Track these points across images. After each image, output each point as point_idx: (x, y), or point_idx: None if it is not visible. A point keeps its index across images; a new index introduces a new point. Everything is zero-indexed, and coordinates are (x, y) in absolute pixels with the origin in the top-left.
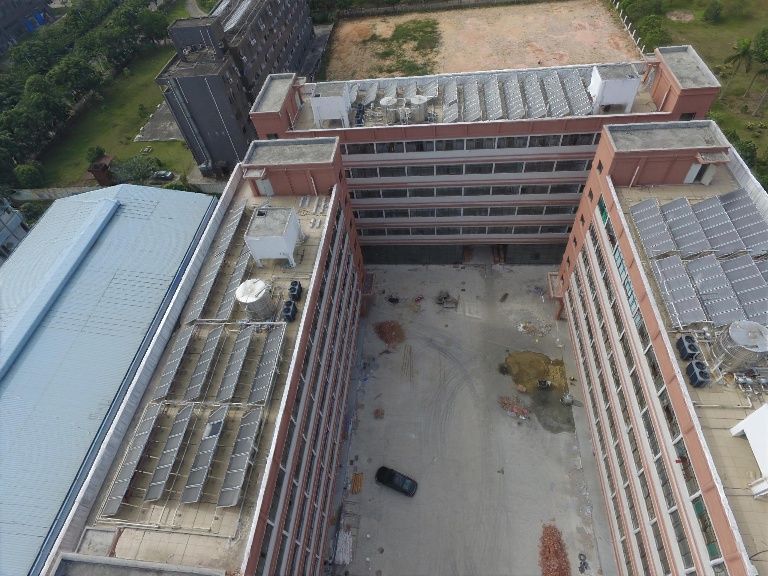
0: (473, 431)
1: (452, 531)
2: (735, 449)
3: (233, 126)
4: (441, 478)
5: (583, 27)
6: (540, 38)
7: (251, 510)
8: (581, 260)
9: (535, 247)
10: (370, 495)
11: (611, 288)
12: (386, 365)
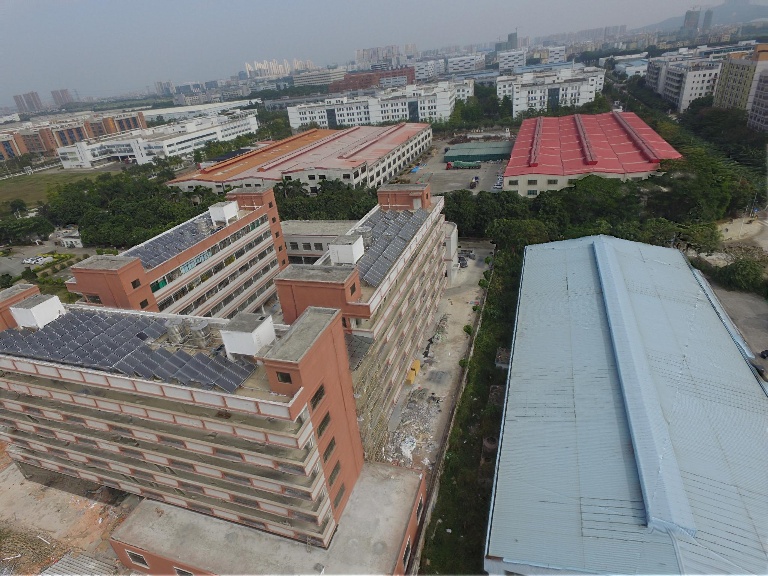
0: None
1: None
2: None
3: None
4: None
5: None
6: None
7: None
8: None
9: None
10: None
11: None
12: None
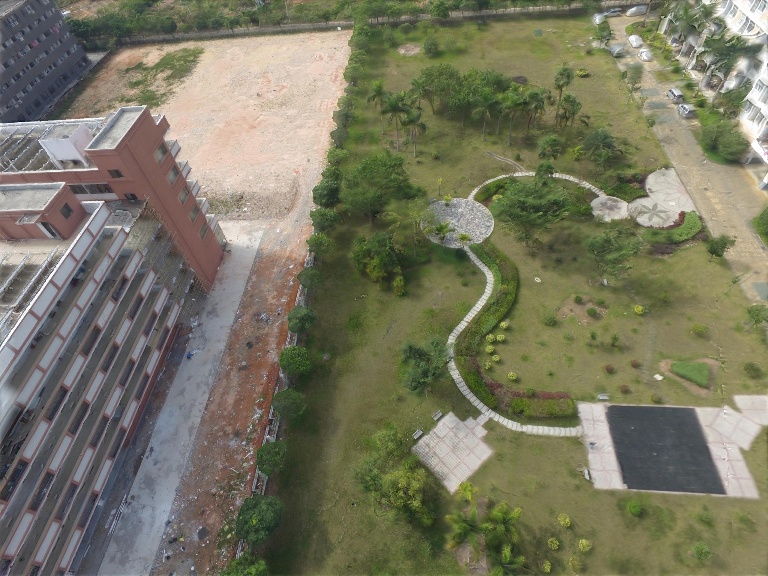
0: None
1: None
2: None
3: None
4: None
5: (321, 59)
6: (277, 69)
7: None
8: None
9: None
10: None
11: None
12: None
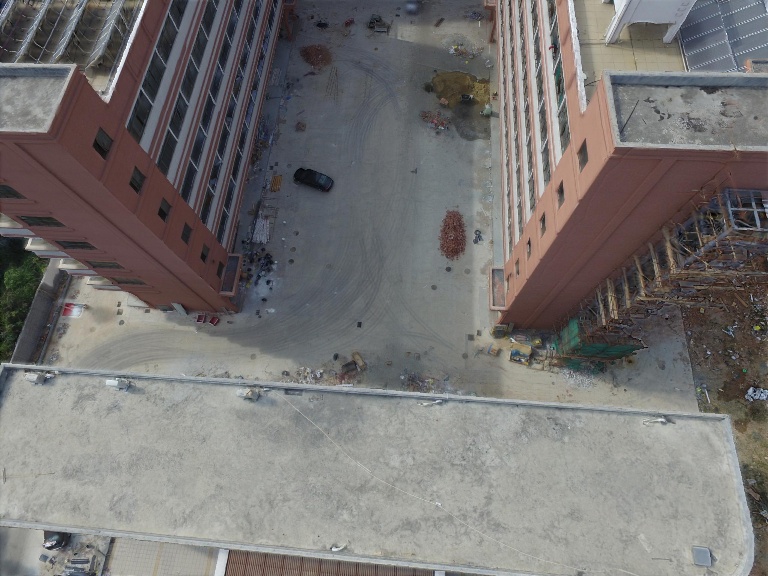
0: (392, 140)
1: (363, 217)
2: (601, 12)
3: None
4: (357, 177)
5: None
6: None
7: None
8: None
9: None
10: (288, 192)
11: None
12: (310, 85)
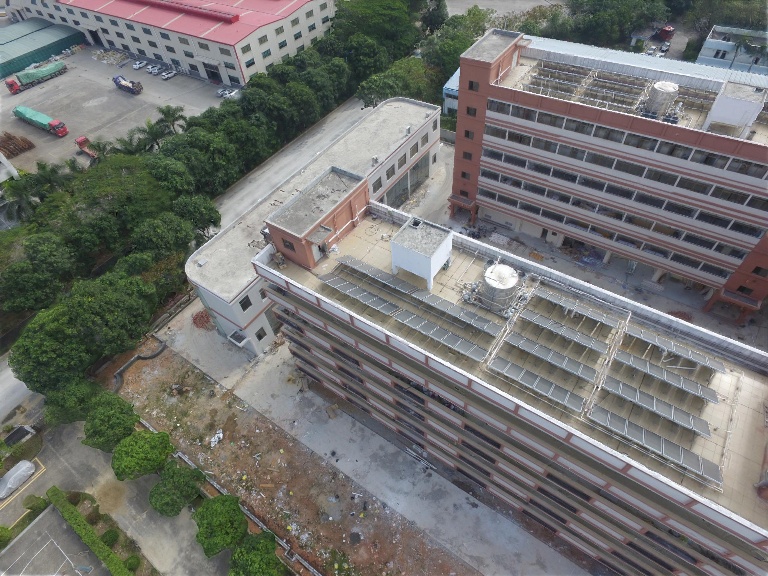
0: None
1: None
2: None
3: None
4: None
5: None
6: None
7: None
8: None
9: None
10: None
11: None
12: None
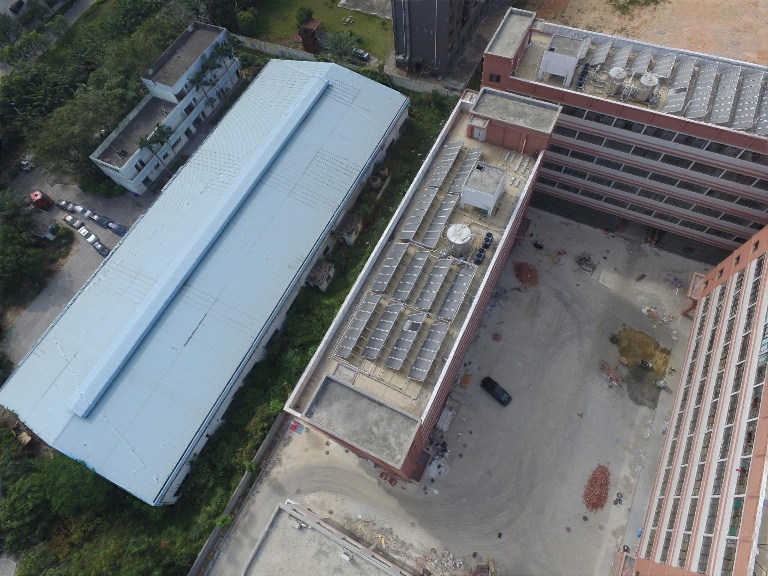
0: (569, 378)
1: (527, 440)
2: None
3: (443, 28)
4: (531, 402)
5: None
6: None
7: (428, 387)
8: (735, 280)
9: (693, 242)
10: (473, 393)
11: (752, 321)
12: (514, 300)
